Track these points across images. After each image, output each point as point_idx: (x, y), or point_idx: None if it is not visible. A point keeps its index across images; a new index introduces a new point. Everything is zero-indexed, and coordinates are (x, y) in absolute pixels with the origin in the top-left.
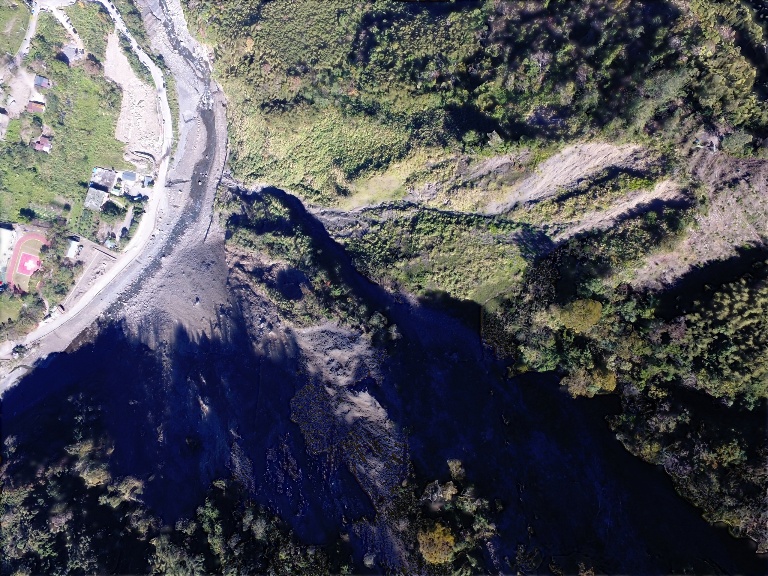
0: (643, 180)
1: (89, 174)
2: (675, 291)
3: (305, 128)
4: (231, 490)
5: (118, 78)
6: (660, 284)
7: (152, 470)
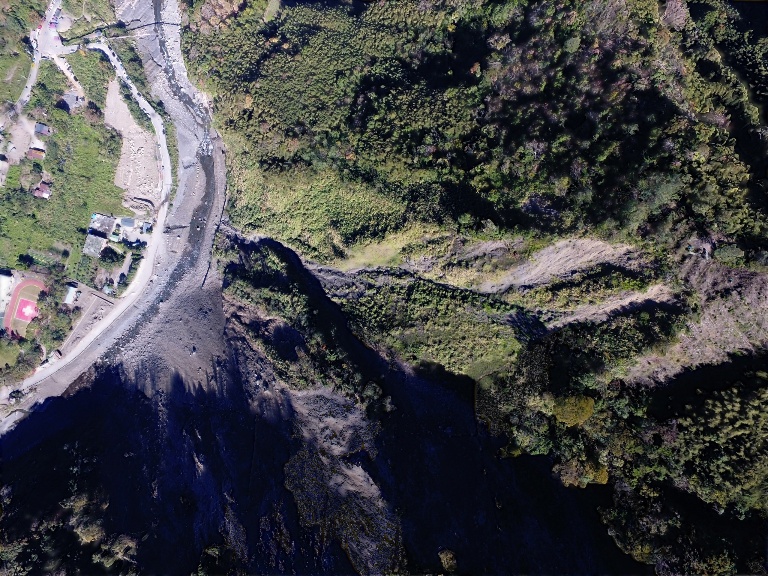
0: (636, 282)
1: (88, 220)
2: (667, 390)
3: (303, 187)
4: (224, 558)
5: (118, 125)
6: (653, 381)
7: (146, 528)
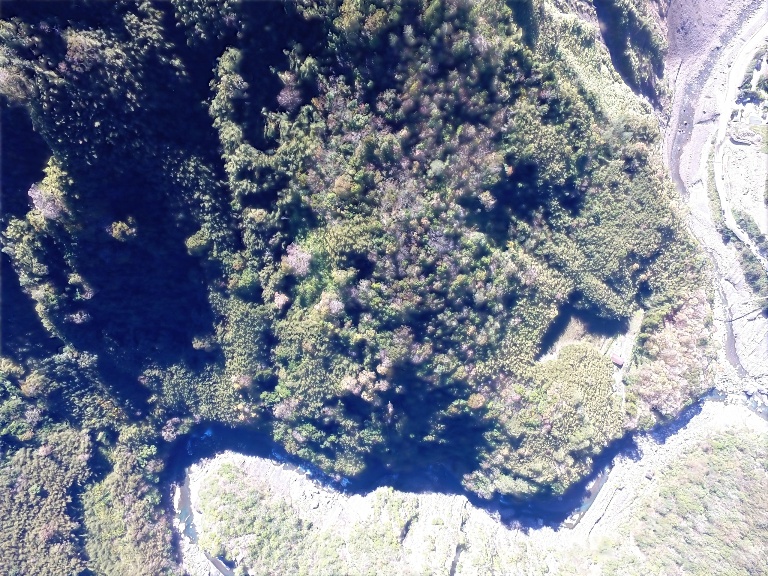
0: None
1: None
2: None
3: None
4: None
5: None
6: None
7: None
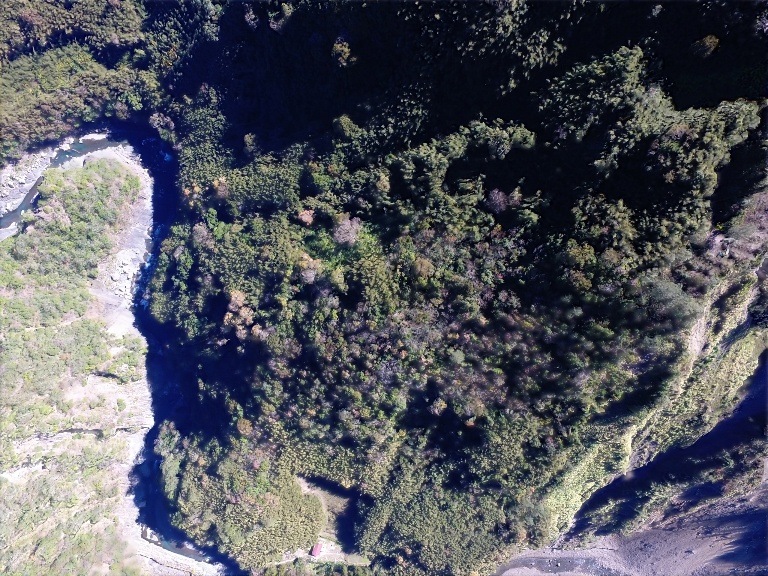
0: (746, 287)
1: None
2: None
3: None
4: None
5: None
6: None
7: None
